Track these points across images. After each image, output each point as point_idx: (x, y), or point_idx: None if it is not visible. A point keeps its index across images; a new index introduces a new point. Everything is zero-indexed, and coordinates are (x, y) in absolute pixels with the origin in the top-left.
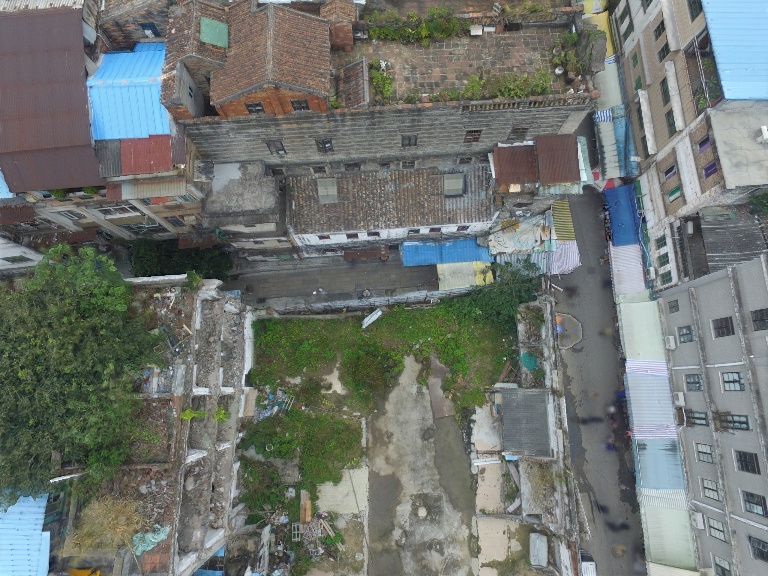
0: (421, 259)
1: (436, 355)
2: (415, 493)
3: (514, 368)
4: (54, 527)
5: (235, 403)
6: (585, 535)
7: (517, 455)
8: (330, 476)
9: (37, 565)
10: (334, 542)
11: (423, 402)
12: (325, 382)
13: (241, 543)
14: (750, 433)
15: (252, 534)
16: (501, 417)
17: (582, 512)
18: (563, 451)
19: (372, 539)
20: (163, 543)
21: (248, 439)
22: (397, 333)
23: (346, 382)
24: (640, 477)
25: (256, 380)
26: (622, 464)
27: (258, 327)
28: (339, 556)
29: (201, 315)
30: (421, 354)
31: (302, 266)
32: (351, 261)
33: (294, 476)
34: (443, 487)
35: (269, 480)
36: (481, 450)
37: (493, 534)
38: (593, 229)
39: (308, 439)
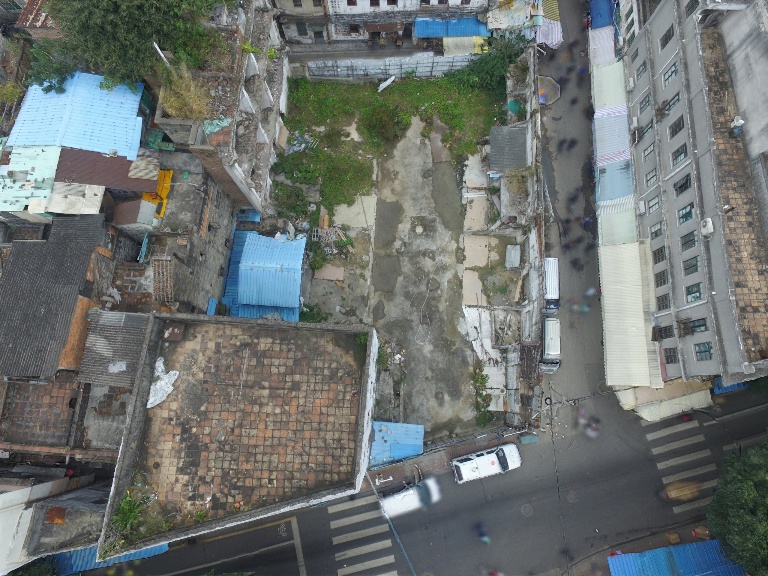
0: (430, 32)
1: (438, 116)
2: (414, 216)
3: (502, 125)
4: (143, 127)
5: (274, 114)
6: (550, 220)
7: (499, 173)
8: (345, 199)
9: (132, 139)
10: (346, 245)
11: (425, 150)
12: (345, 131)
13: (273, 221)
14: (679, 102)
15: (282, 217)
16: (489, 163)
17: (548, 202)
18: (536, 152)
19: (377, 247)
20: (226, 129)
21: (280, 163)
22: (407, 97)
23: (362, 132)
24: (599, 194)
25: (288, 127)
26: (587, 204)
27: (292, 85)
28: (349, 257)
29: (254, 21)
30: (426, 114)
31: (330, 49)
32: (371, 45)
33: (316, 198)
34: (438, 212)
35: (295, 198)
36: (471, 186)
37: (476, 247)
38: (577, 29)
39: (328, 171)
